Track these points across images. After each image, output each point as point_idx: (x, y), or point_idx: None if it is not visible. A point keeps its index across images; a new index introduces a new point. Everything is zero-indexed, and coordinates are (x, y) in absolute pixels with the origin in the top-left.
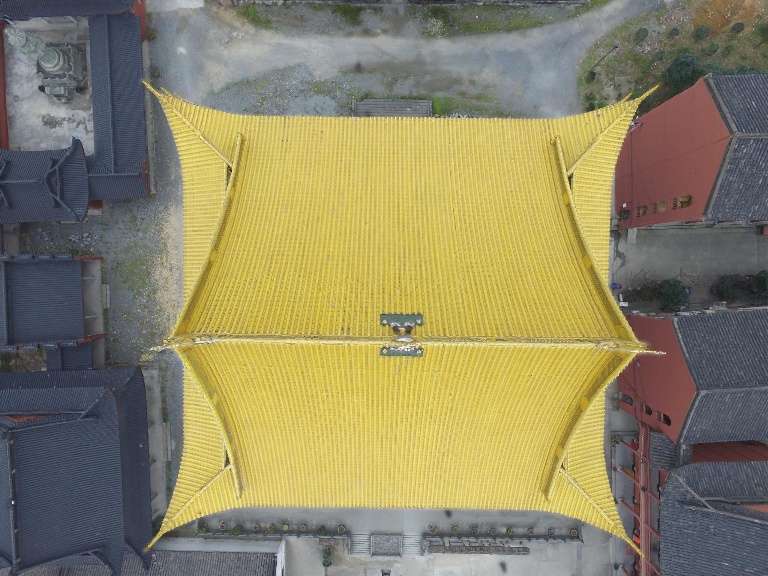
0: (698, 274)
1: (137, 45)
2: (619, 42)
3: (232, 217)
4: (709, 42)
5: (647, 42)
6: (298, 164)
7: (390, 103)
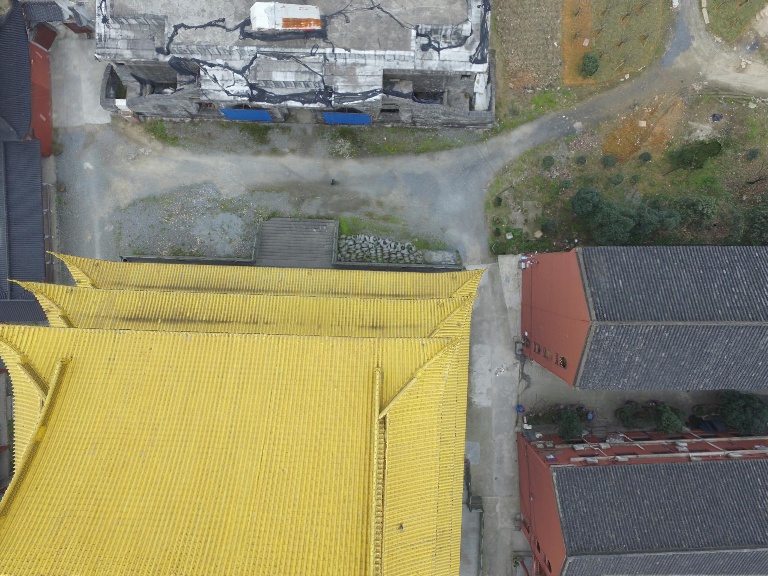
0: (603, 398)
1: (36, 169)
2: (527, 167)
3: (38, 460)
4: (618, 168)
5: (556, 167)
6: (119, 390)
7: (297, 223)
